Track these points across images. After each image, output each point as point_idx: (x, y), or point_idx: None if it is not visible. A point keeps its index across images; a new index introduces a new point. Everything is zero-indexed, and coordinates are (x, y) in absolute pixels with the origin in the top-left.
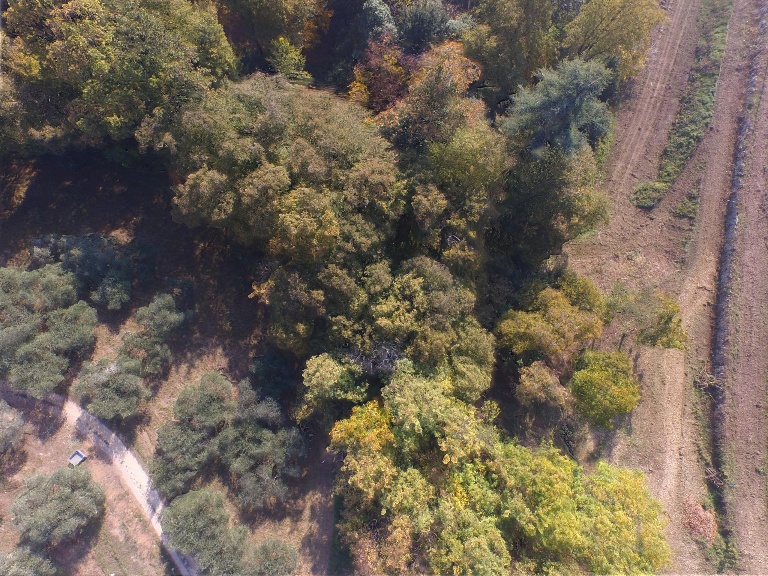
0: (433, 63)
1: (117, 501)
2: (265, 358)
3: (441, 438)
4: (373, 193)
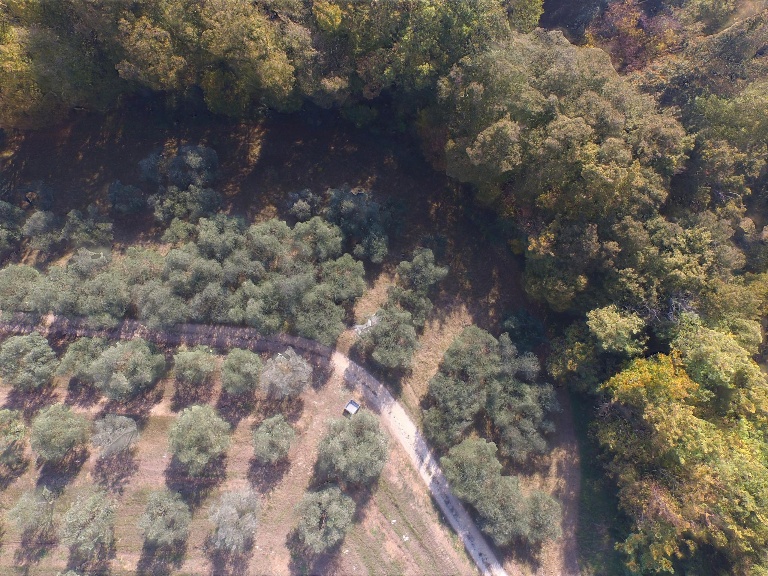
0: (676, 25)
1: (391, 450)
2: (522, 314)
3: (744, 388)
4: (663, 147)
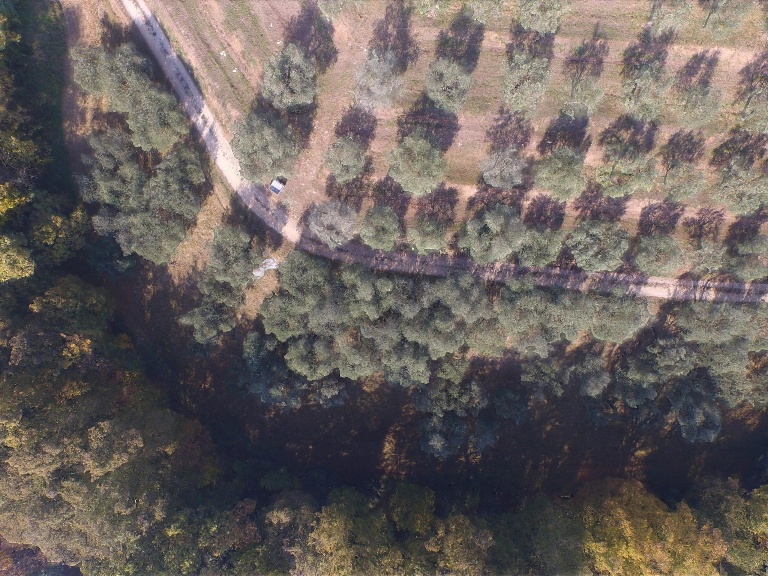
0: None
1: None
2: None
3: None
4: None
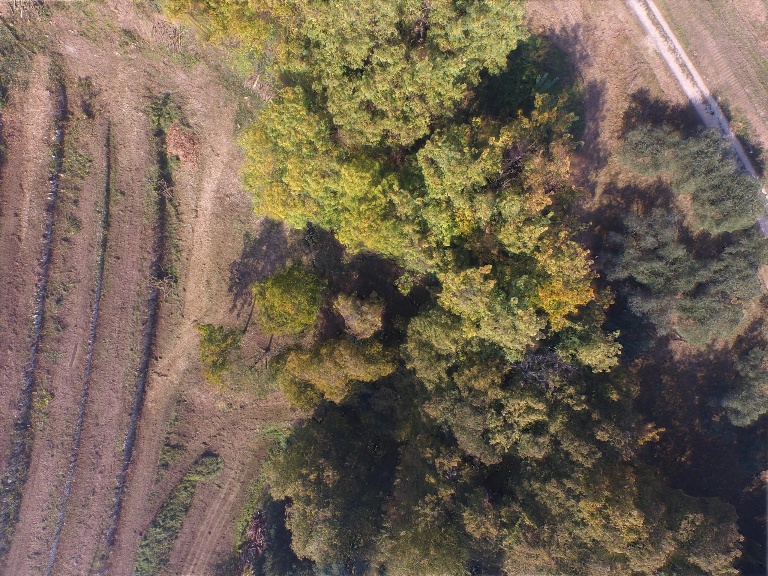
0: None
1: None
2: None
3: None
4: None
